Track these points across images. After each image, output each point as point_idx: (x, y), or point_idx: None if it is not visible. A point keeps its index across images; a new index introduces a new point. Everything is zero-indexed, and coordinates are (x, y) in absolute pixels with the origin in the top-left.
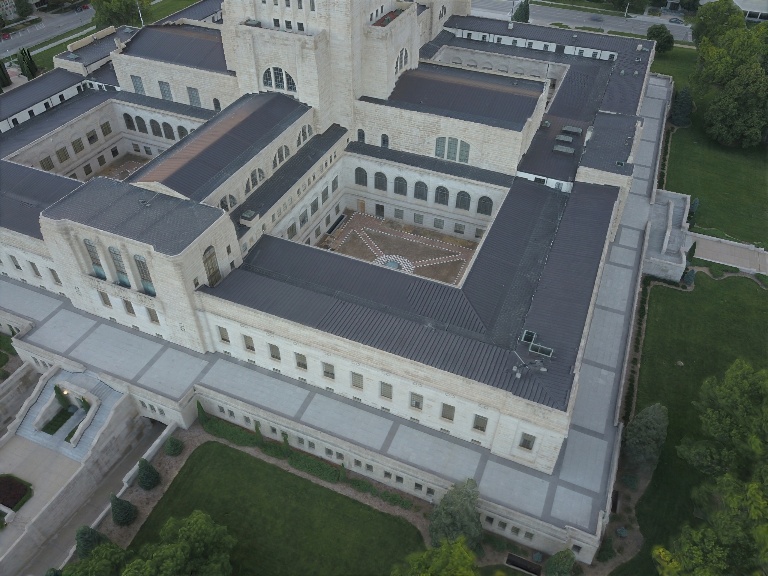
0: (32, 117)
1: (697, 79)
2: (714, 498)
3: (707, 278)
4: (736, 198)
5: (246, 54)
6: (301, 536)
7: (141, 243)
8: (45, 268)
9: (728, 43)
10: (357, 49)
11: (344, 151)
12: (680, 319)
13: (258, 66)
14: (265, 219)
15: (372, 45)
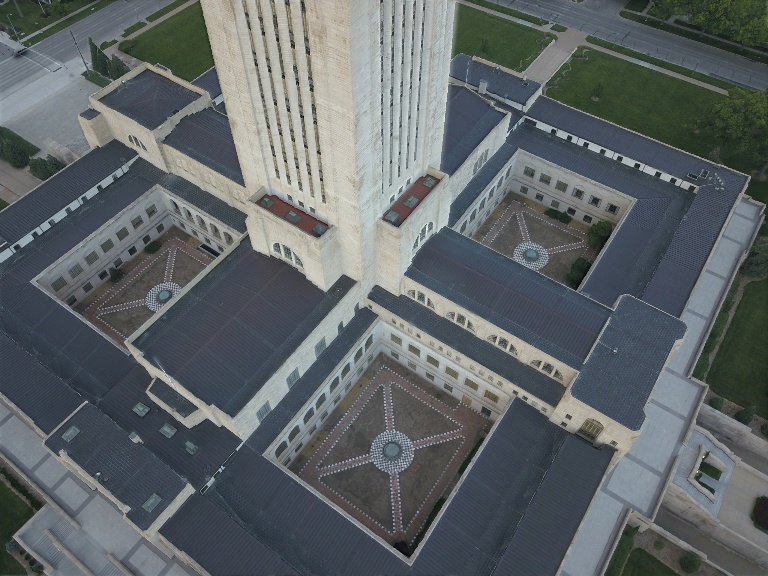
0: None
1: None
2: (760, 153)
3: None
4: None
5: (408, 243)
6: (763, 337)
7: None
8: None
9: None
10: None
11: None
12: None
13: None
14: None
15: None
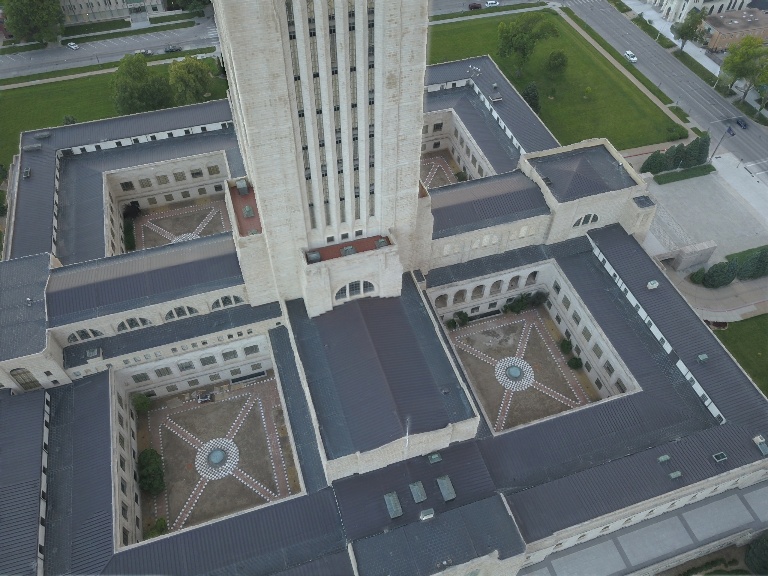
0: (170, 137)
1: None
2: None
3: None
4: None
5: None
6: None
7: None
8: None
9: None
10: (288, 265)
11: (267, 331)
12: None
13: None
14: (111, 361)
15: None
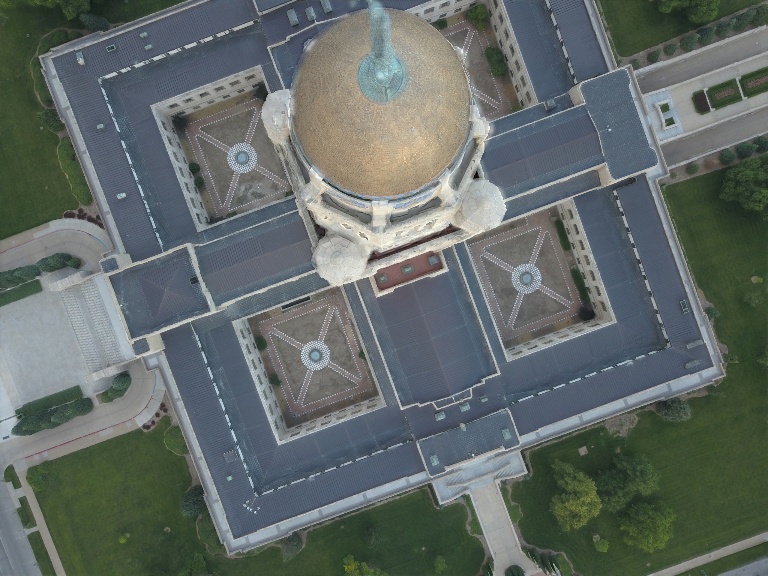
0: None
1: (75, 8)
2: None
3: None
4: None
5: None
6: None
7: None
8: None
9: None
10: None
11: None
12: None
13: None
14: None
15: None
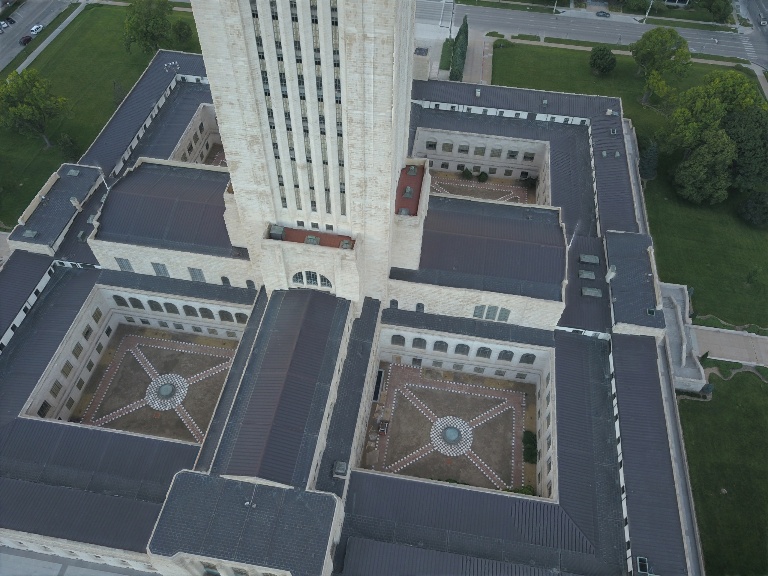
0: (15, 331)
1: (664, 138)
2: None
3: (719, 380)
4: (718, 270)
5: (274, 263)
6: None
7: (275, 570)
8: (139, 564)
9: (690, 103)
10: (390, 239)
11: (381, 324)
12: (711, 437)
13: (288, 270)
14: (351, 459)
15: (403, 230)
